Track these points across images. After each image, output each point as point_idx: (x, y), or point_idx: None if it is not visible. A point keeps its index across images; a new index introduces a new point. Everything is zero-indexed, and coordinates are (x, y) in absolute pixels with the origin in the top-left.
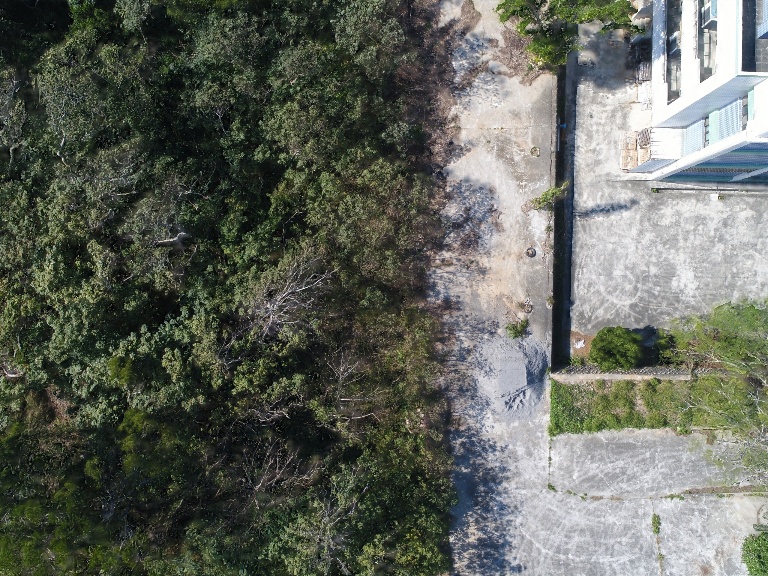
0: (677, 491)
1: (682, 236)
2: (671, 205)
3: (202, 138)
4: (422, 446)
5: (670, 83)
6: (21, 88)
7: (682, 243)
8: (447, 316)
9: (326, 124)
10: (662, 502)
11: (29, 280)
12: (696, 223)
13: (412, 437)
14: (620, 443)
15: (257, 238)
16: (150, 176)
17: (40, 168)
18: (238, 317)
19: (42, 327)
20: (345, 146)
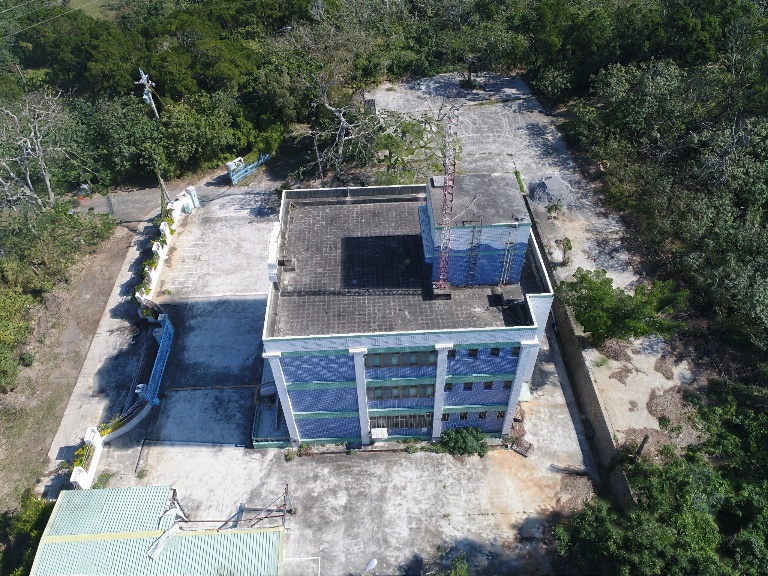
0: None
1: None
2: None
3: None
4: None
5: None
6: None
7: None
8: None
9: None
10: None
11: None
12: None
13: None
14: None
15: None
16: None
17: None
18: None
19: None
20: (726, 253)
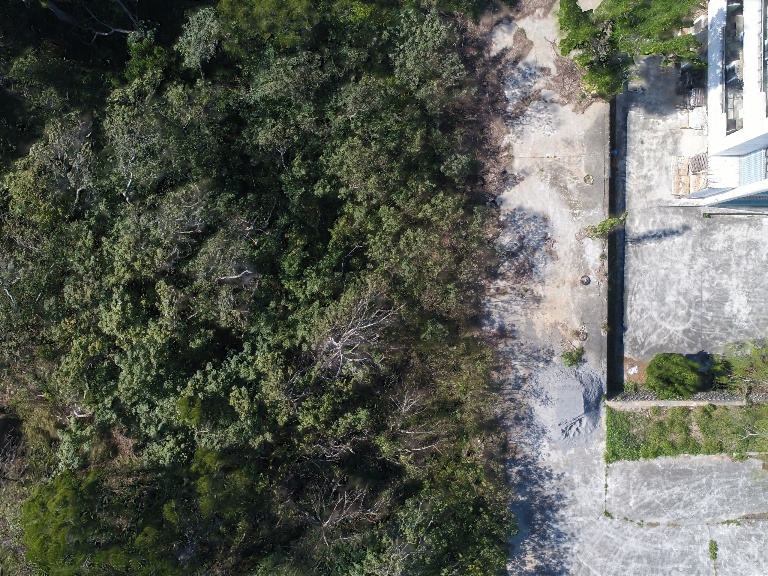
0: (733, 517)
1: (734, 261)
2: (723, 230)
3: (259, 172)
4: (483, 477)
5: (727, 112)
6: (85, 128)
7: (735, 268)
8: (502, 345)
9: (386, 158)
10: (719, 528)
11: (95, 319)
12: (748, 248)
13: (474, 469)
14: (676, 469)
15: (319, 273)
16: (211, 213)
17: (104, 207)
18: (301, 352)
19: (109, 366)
20: (403, 179)
